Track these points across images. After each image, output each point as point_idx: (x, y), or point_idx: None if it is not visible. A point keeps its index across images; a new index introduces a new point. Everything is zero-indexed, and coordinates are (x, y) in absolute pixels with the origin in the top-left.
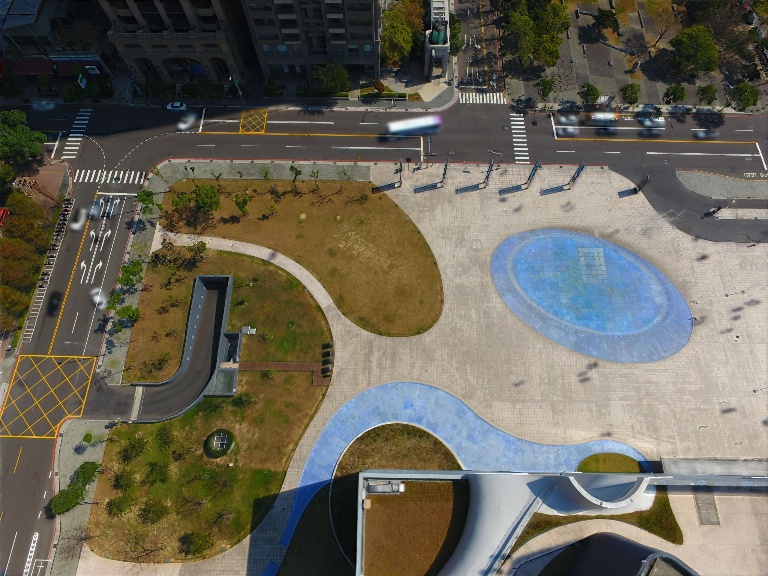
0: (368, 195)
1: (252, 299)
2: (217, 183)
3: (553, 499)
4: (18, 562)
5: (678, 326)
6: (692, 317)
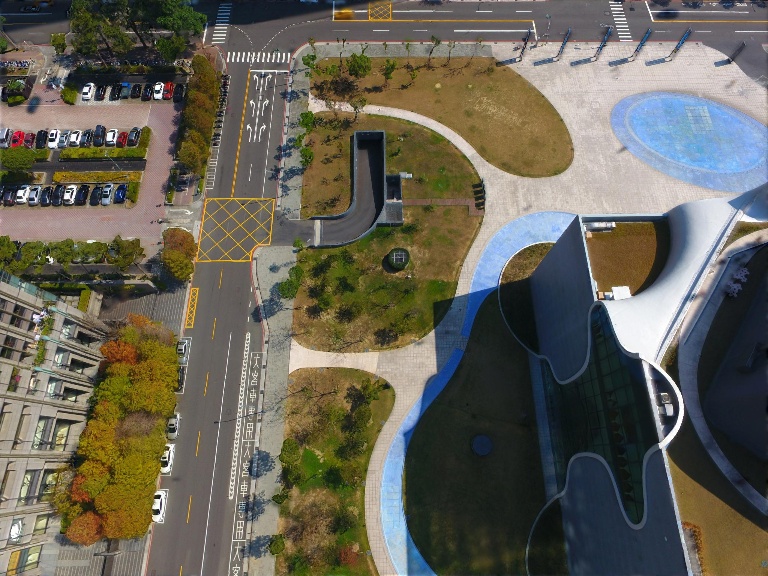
0: (493, 68)
1: (405, 151)
2: None
3: (753, 209)
4: (237, 355)
5: None
6: None
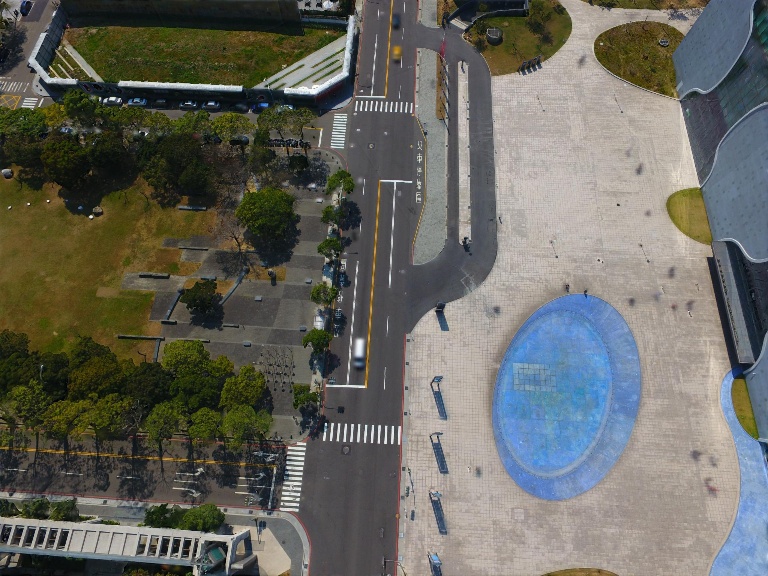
0: None
1: None
2: None
3: None
4: None
5: (594, 309)
6: (584, 294)
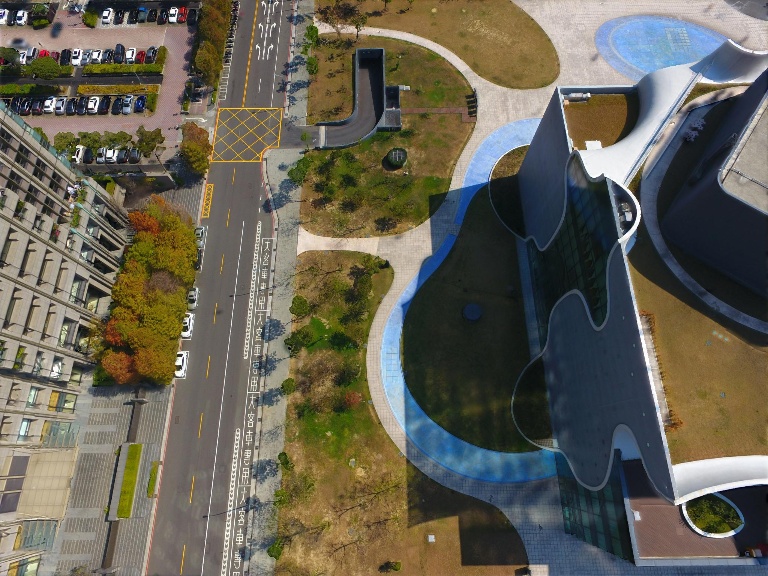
0: None
1: (403, 67)
2: None
3: (711, 72)
4: (249, 240)
5: None
6: None
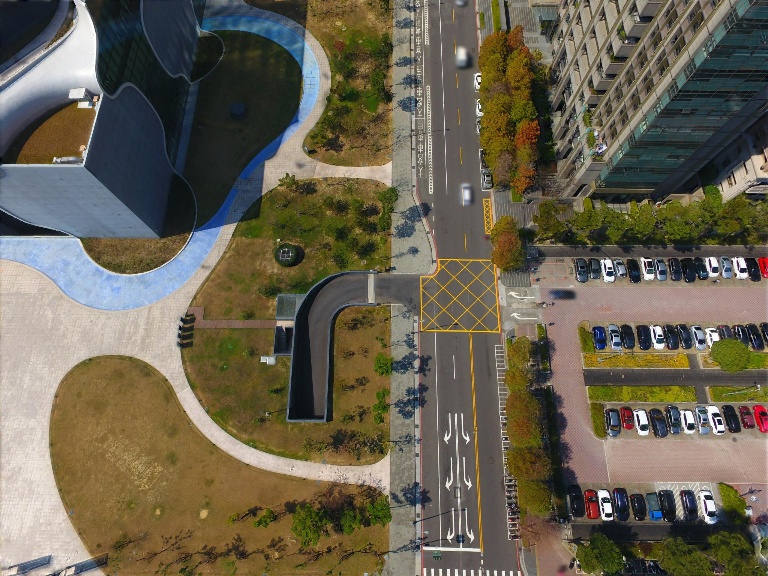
0: (114, 551)
1: (266, 396)
2: (320, 571)
3: None
4: (439, 177)
5: None
6: None
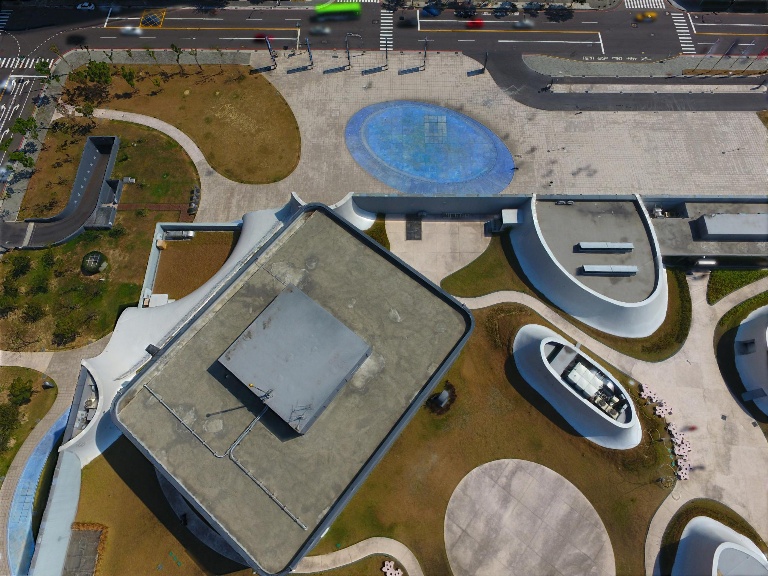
0: (246, 75)
1: (135, 156)
2: None
3: None
4: None
5: (501, 175)
6: (514, 167)
